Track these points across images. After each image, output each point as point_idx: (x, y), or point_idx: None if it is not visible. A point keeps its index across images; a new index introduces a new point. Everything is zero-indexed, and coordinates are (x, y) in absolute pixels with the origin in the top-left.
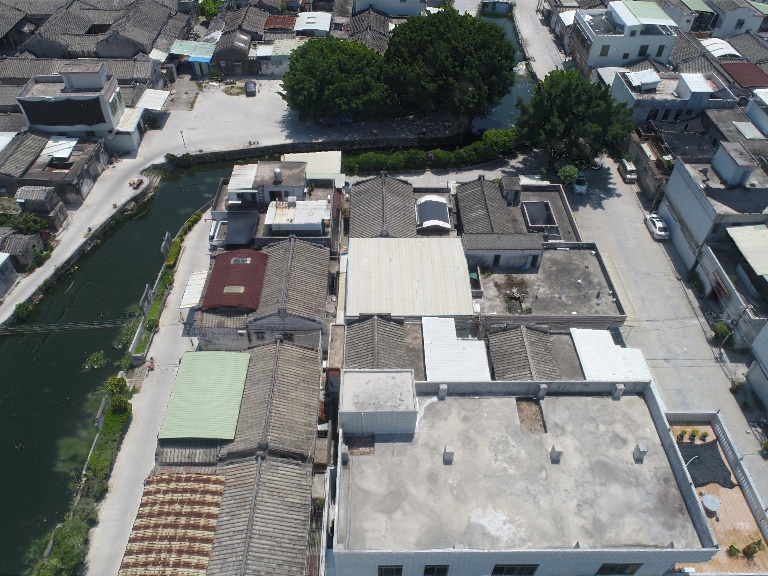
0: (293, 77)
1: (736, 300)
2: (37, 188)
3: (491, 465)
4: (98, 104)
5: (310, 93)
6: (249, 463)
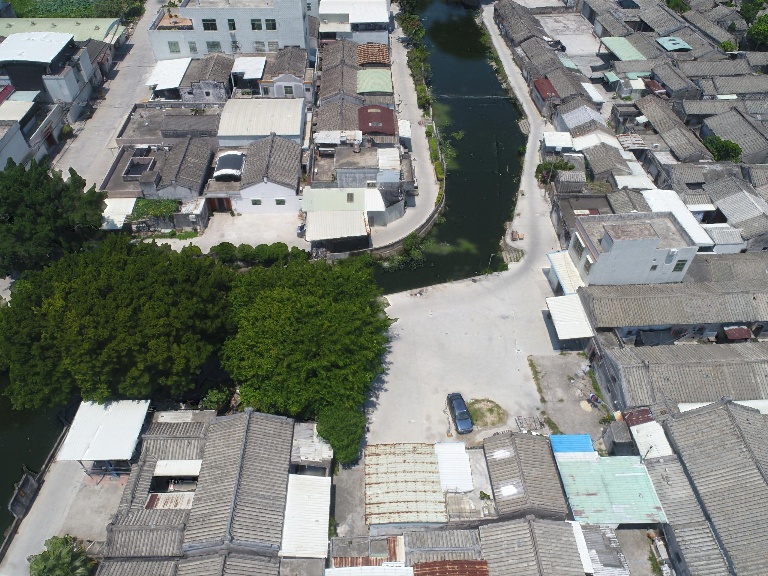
0: (365, 272)
1: (53, 116)
2: (571, 175)
3: (251, 3)
4: None
5: None
6: None
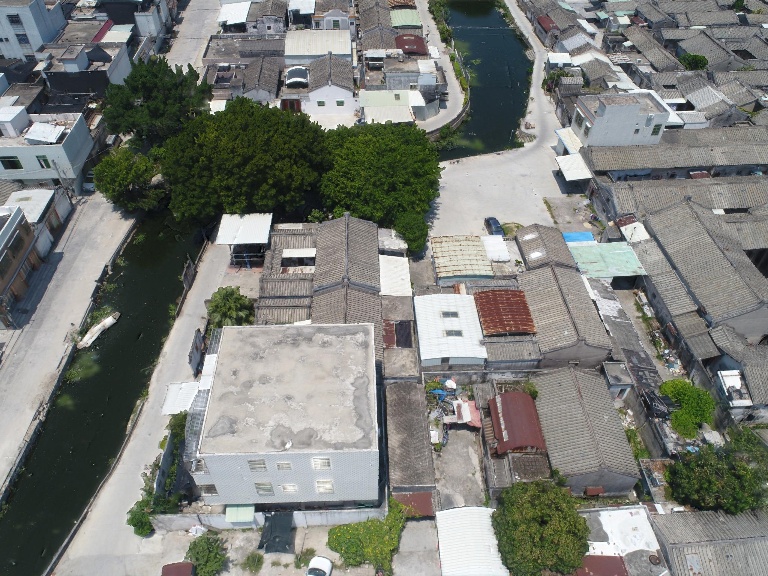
0: None
1: (144, 45)
2: (571, 79)
3: None
4: None
5: None
6: (381, 5)
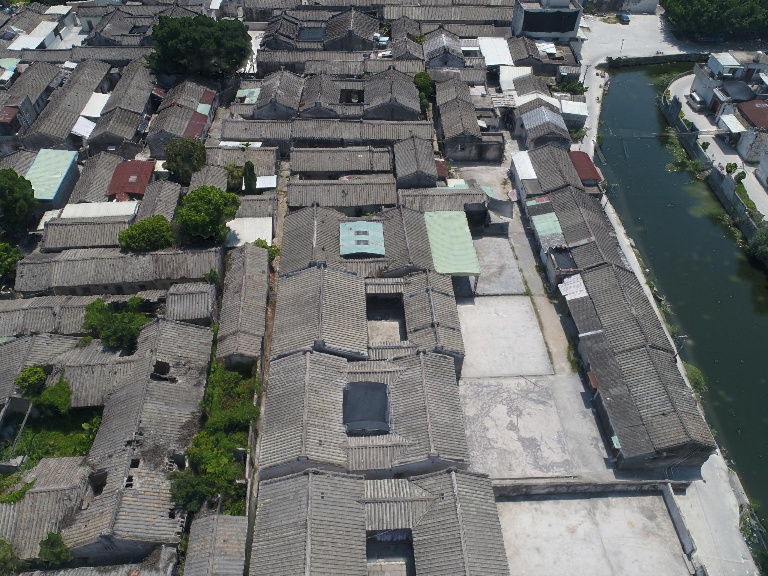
0: (698, 3)
1: None
2: None
3: None
4: (576, 16)
5: (711, 15)
6: None
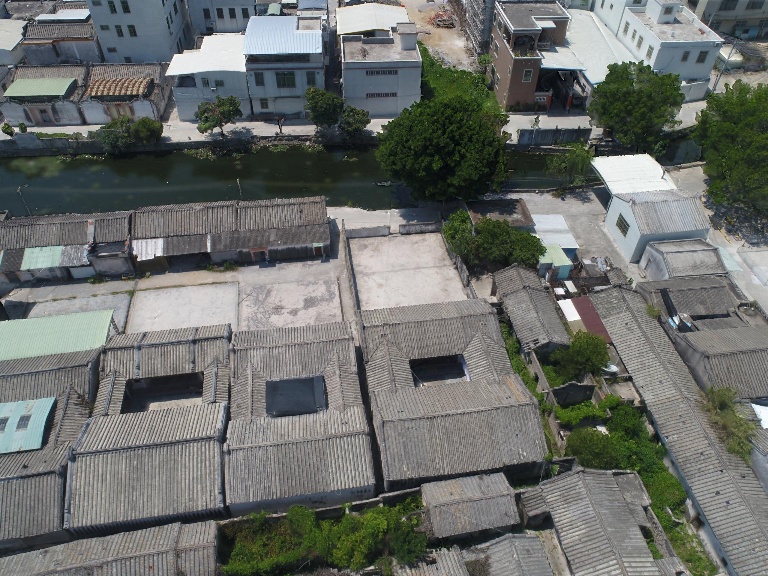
0: None
1: None
2: None
3: None
4: None
5: None
6: (93, 70)
